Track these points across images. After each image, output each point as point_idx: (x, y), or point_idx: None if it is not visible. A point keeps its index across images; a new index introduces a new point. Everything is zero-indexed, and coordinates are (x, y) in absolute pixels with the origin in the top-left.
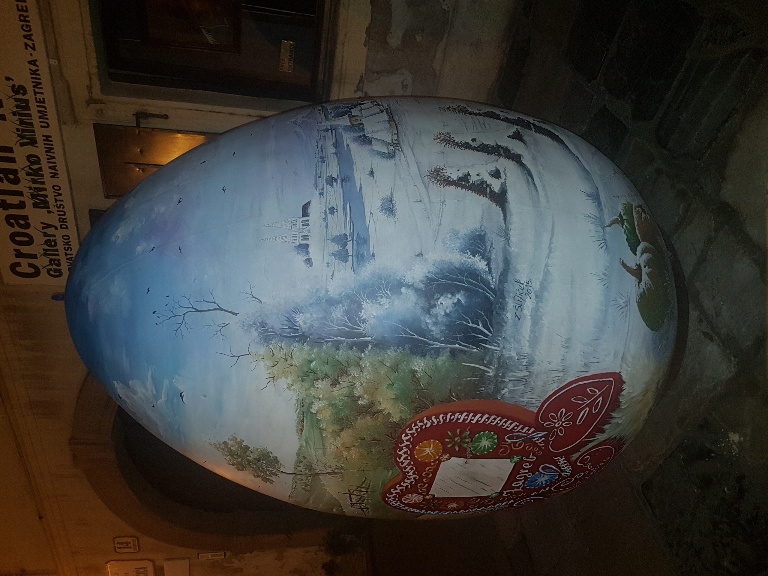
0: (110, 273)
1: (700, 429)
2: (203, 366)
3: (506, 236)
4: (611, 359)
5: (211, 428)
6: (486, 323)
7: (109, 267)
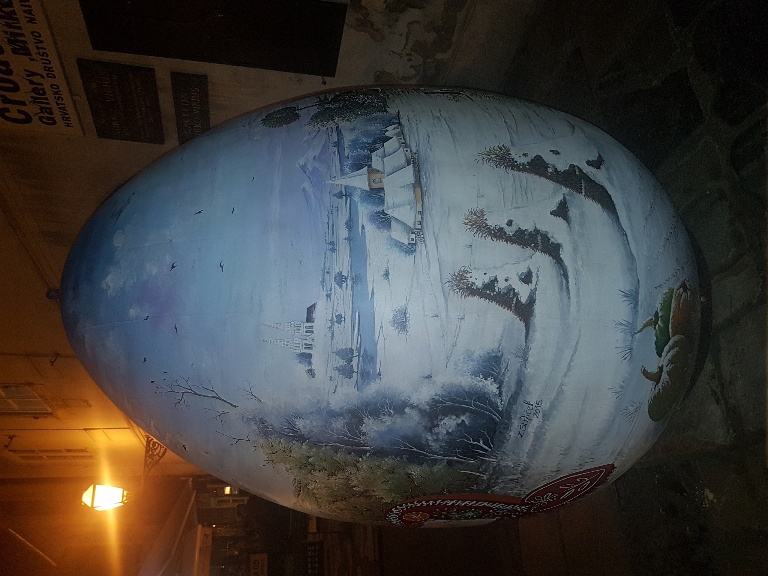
0: (104, 325)
1: (681, 467)
2: (204, 436)
3: (524, 356)
4: (607, 456)
5: (213, 470)
6: (487, 441)
7: (102, 318)
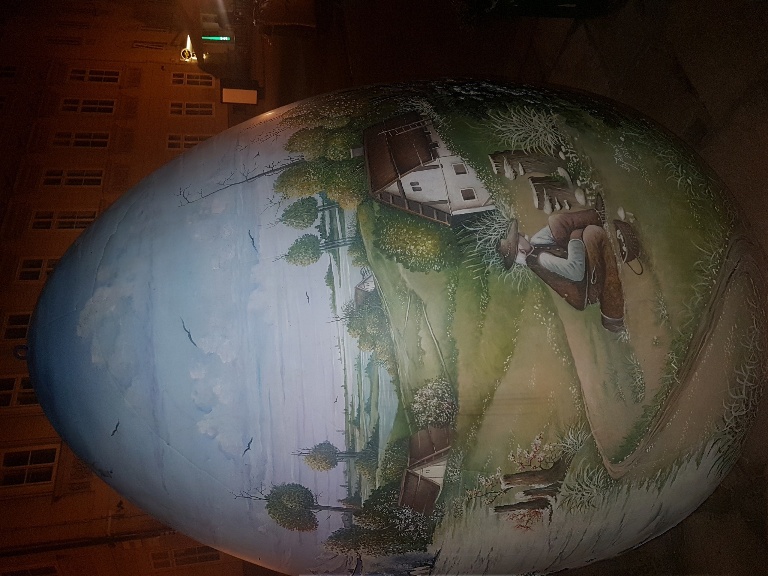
0: None
1: None
2: None
3: None
4: None
5: None
6: None
7: None
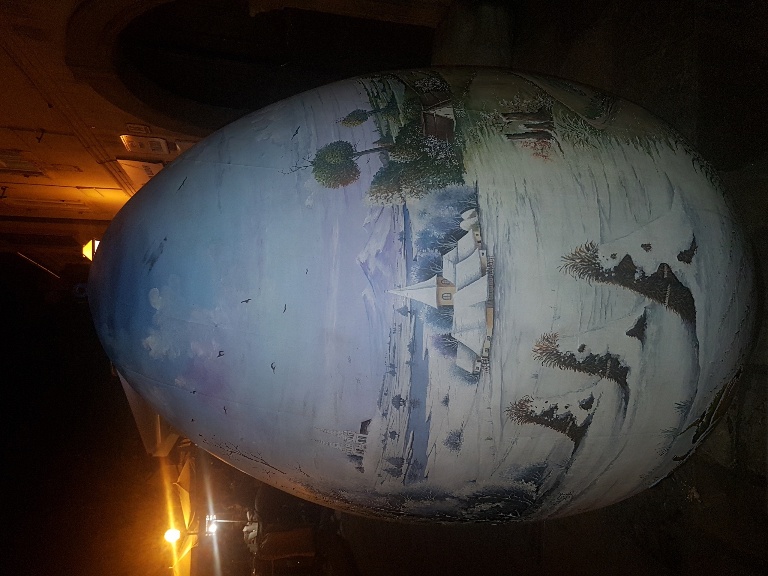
0: (147, 379)
1: None
2: None
3: (567, 466)
4: None
5: None
6: (516, 513)
7: (145, 372)
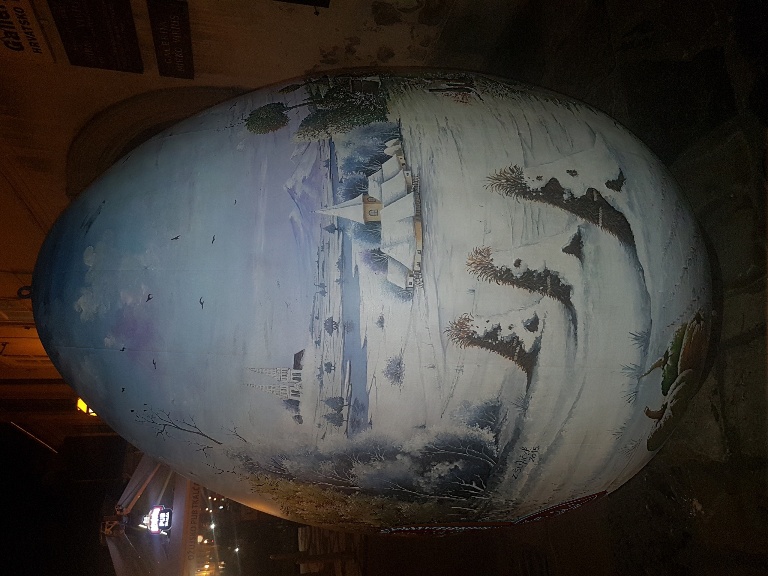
0: (78, 349)
1: (671, 471)
2: (188, 462)
3: (524, 406)
4: (601, 486)
5: None
6: (480, 483)
7: (76, 341)
